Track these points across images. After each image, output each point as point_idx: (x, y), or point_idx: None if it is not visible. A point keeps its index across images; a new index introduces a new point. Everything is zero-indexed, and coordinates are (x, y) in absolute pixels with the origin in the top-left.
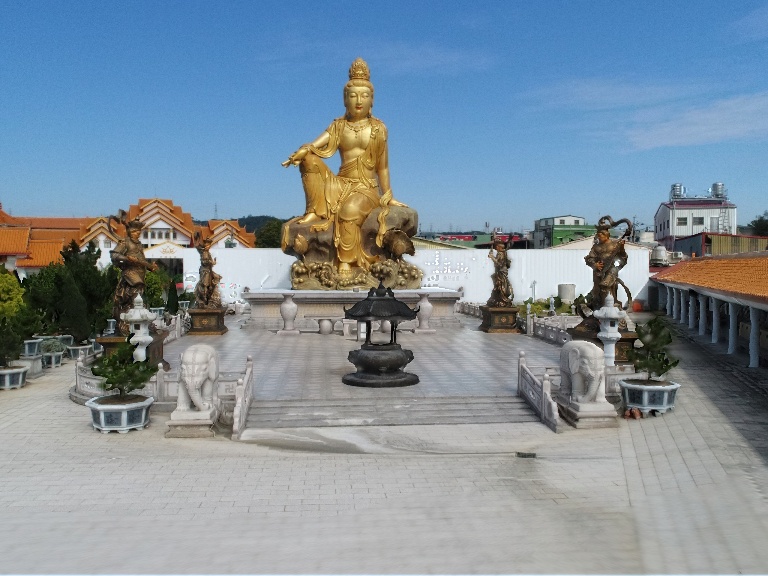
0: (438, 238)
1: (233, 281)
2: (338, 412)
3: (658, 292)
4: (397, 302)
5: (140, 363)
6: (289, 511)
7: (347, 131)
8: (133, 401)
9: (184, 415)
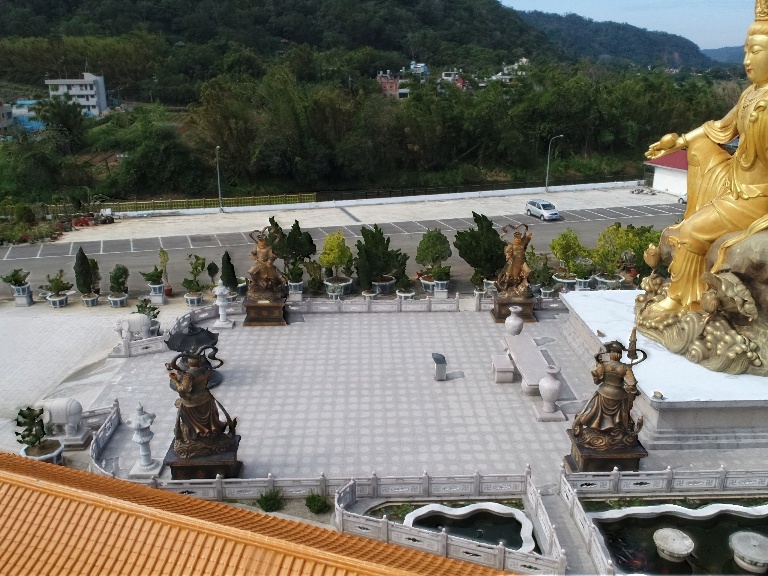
0: None
1: None
2: None
3: None
4: (181, 336)
5: None
6: (2, 370)
7: None
8: None
9: None
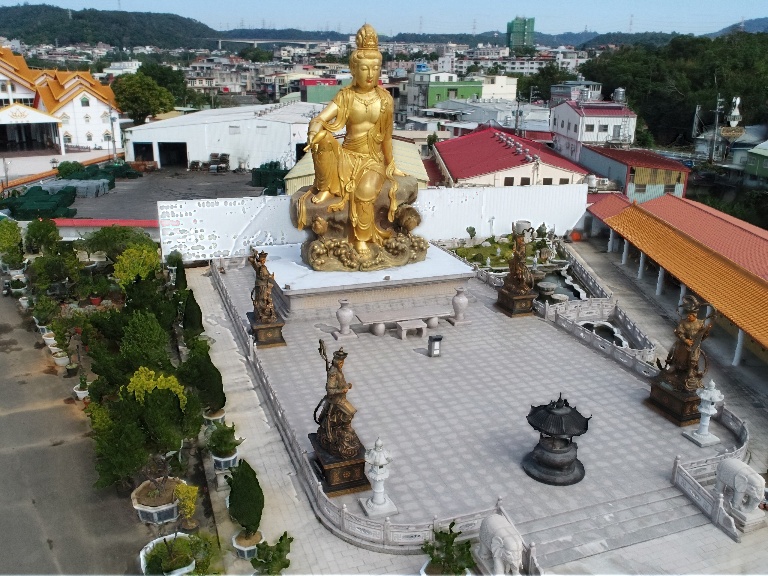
0: None
1: (212, 232)
2: (574, 534)
3: (592, 221)
4: (575, 414)
5: None
6: None
7: (357, 104)
8: None
9: None
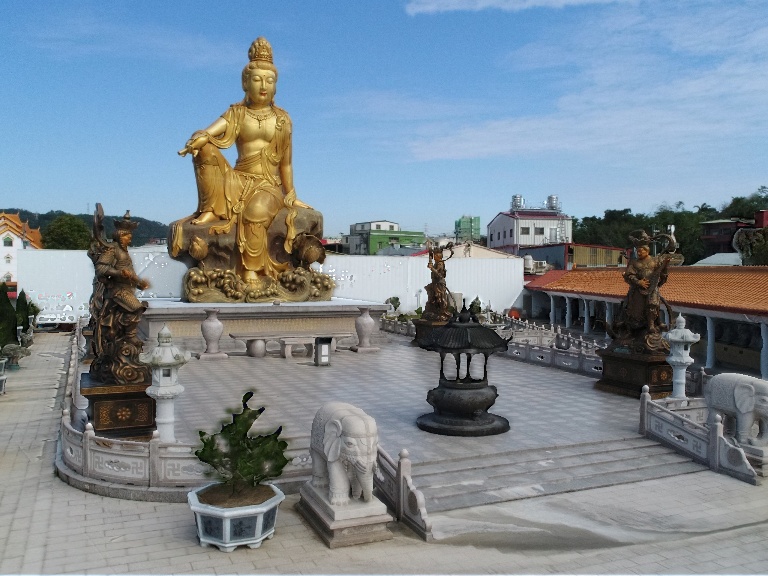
0: None
1: (83, 290)
2: (487, 478)
3: (532, 300)
4: (487, 329)
5: (270, 438)
6: None
7: (248, 119)
8: (253, 494)
9: (353, 512)
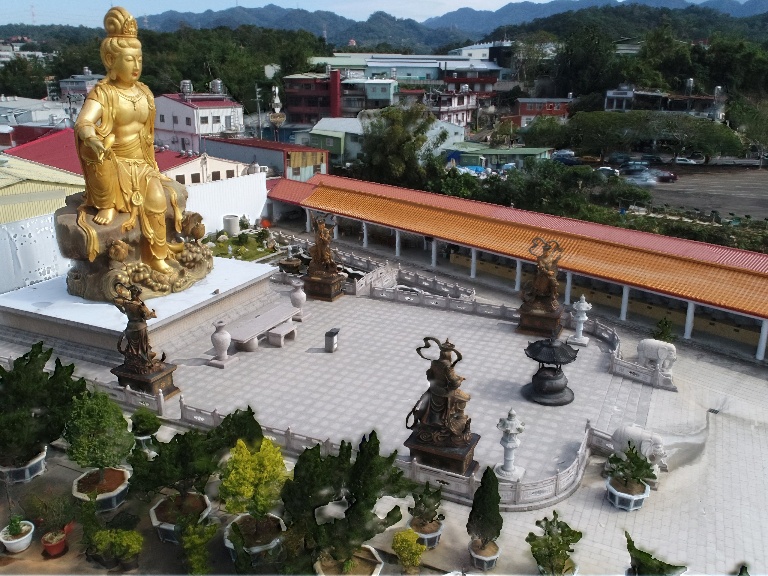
0: (7, 163)
1: None
2: None
3: (273, 207)
4: None
5: None
6: None
7: (123, 102)
8: (629, 482)
9: None
